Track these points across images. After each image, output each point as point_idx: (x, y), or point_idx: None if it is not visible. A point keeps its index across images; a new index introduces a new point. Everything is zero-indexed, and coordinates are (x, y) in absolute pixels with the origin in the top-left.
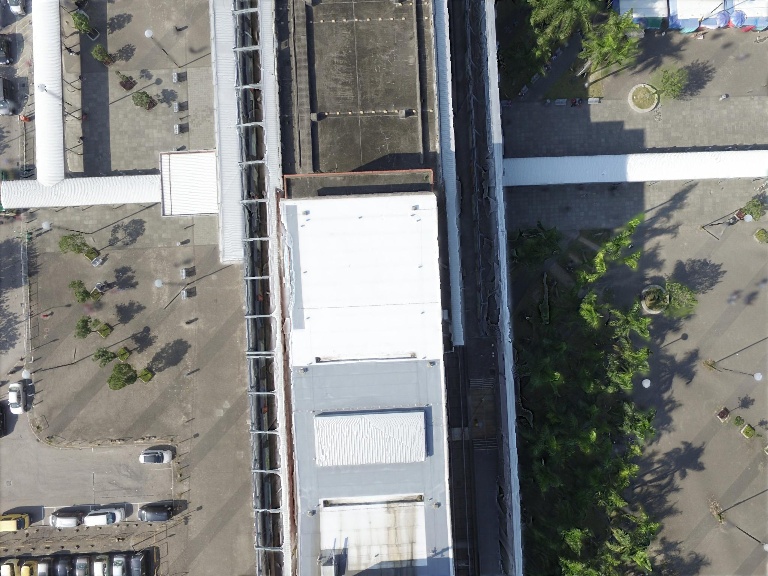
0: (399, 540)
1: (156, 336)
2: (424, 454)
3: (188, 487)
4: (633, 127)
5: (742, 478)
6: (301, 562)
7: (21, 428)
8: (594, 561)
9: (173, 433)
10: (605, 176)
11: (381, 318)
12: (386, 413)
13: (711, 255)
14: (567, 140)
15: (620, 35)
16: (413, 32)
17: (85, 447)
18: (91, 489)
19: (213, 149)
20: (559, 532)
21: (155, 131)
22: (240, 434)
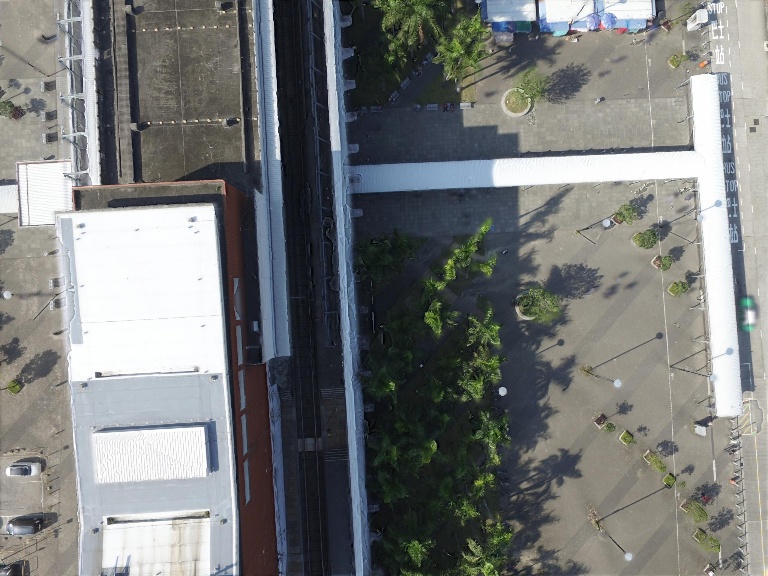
0: (183, 557)
1: (25, 347)
2: (205, 470)
3: (58, 500)
4: (507, 131)
5: (621, 485)
6: None
7: None
8: (454, 572)
9: (43, 445)
10: (471, 181)
11: (161, 332)
12: (166, 428)
13: (587, 260)
14: (440, 145)
15: (468, 40)
16: (237, 40)
17: None
18: None
19: (70, 159)
20: (400, 544)
21: (24, 141)
22: None
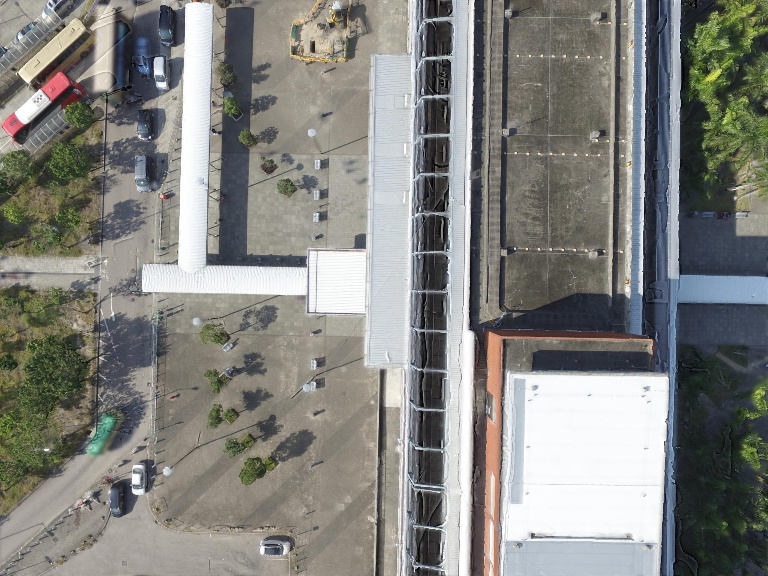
0: None
1: (282, 425)
2: None
3: None
4: None
5: None
6: None
7: (140, 508)
8: None
9: (293, 524)
10: (755, 298)
11: (602, 498)
12: None
13: None
14: (711, 253)
15: None
16: (608, 170)
17: (203, 532)
18: (206, 575)
19: (362, 249)
20: None
21: (293, 217)
22: (360, 530)
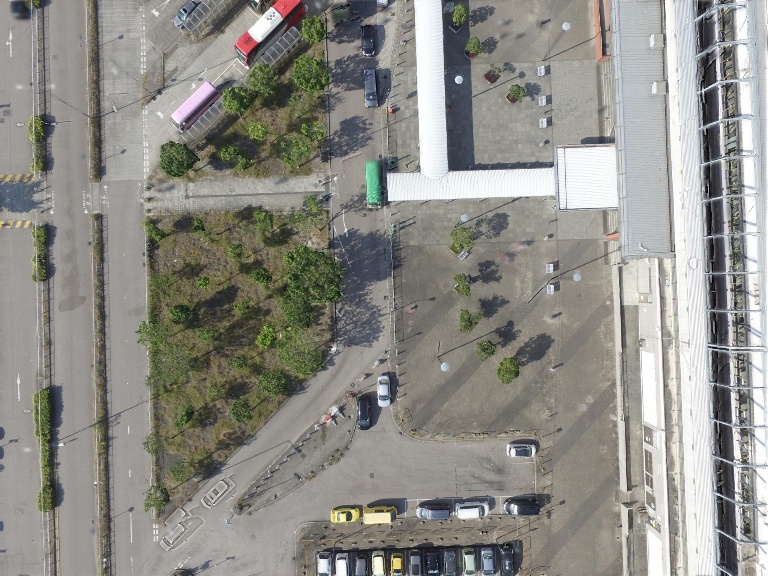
0: None
1: (520, 330)
2: None
3: (551, 481)
4: None
5: None
6: None
7: (384, 421)
8: None
9: (536, 427)
10: None
11: None
12: None
13: None
14: None
15: None
16: None
17: (448, 440)
18: (454, 482)
19: (610, 143)
20: None
21: (519, 125)
22: (603, 429)
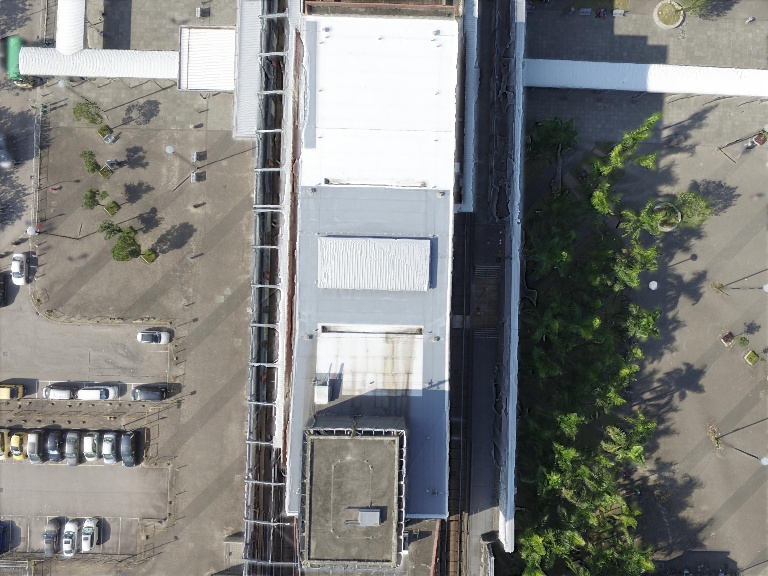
0: (396, 370)
1: (162, 218)
2: (427, 283)
3: (183, 371)
4: (656, 43)
5: (742, 404)
6: (295, 383)
7: (21, 300)
8: (587, 463)
9: (172, 316)
10: (625, 84)
11: (393, 143)
12: (392, 238)
13: (726, 178)
14: (589, 51)
15: None
16: None
17: (84, 323)
18: (87, 366)
19: (233, 26)
20: (555, 416)
21: (176, 14)
22: (239, 322)
